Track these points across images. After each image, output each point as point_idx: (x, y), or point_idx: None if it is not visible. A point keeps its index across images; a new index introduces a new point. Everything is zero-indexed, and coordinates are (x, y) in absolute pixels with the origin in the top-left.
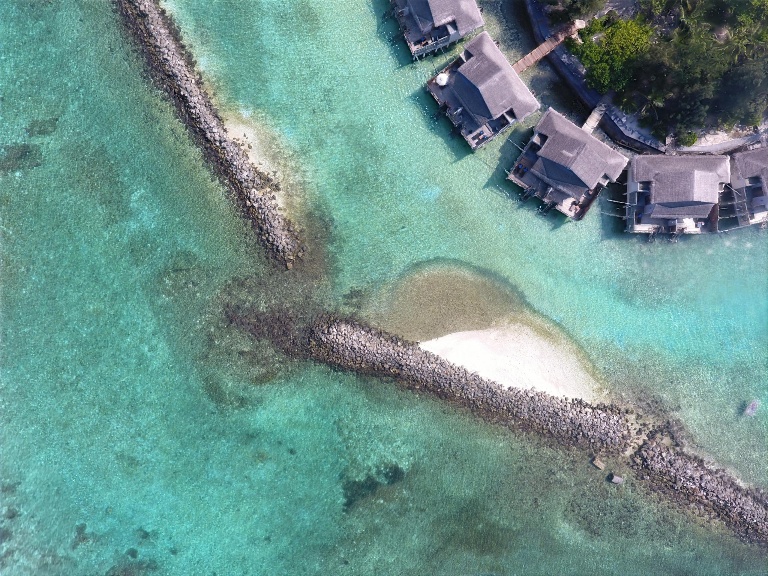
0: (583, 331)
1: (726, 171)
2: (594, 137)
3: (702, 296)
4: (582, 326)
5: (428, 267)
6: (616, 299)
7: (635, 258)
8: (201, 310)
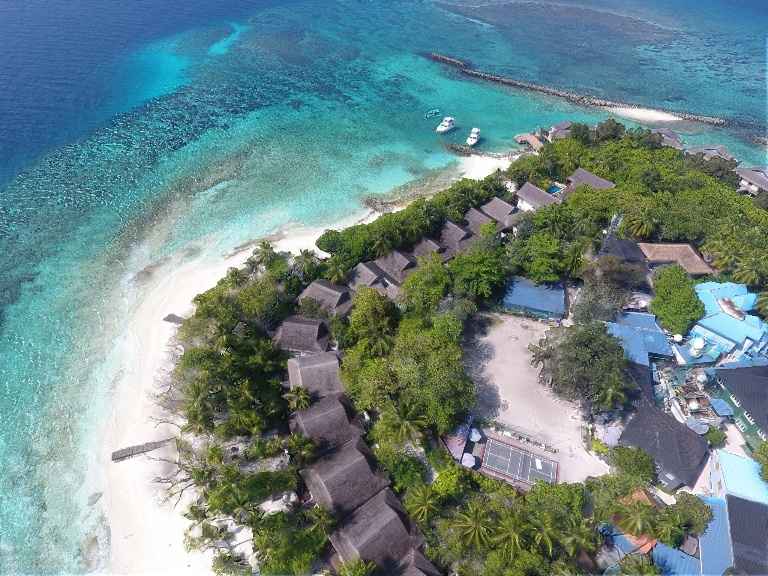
0: None
1: None
2: None
3: None
4: None
5: None
6: None
7: None
8: None
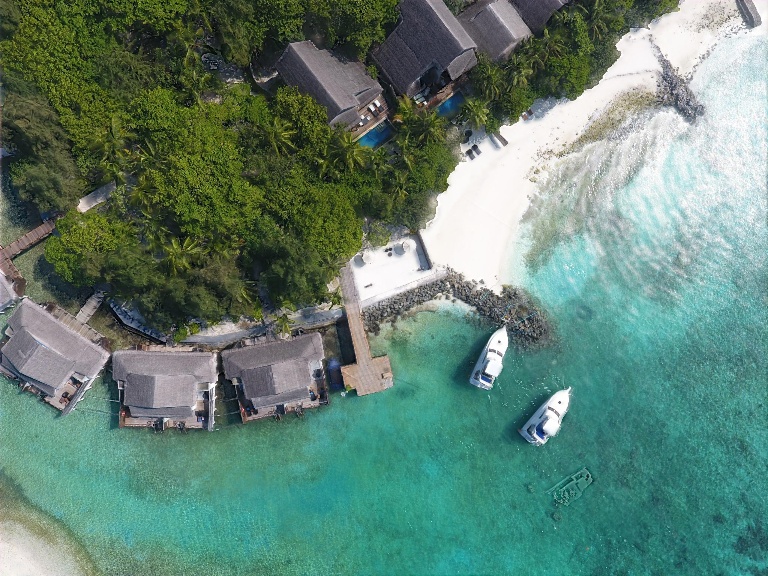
0: (85, 528)
1: (209, 370)
2: (71, 331)
3: (218, 489)
4: (85, 522)
5: None
6: (125, 492)
7: (146, 448)
8: None
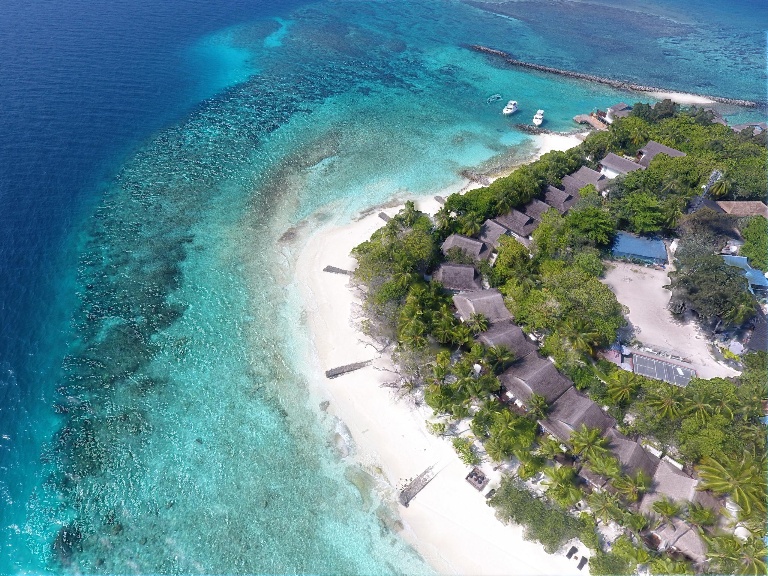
0: None
1: None
2: None
3: None
4: None
5: (730, 114)
6: None
7: None
8: None
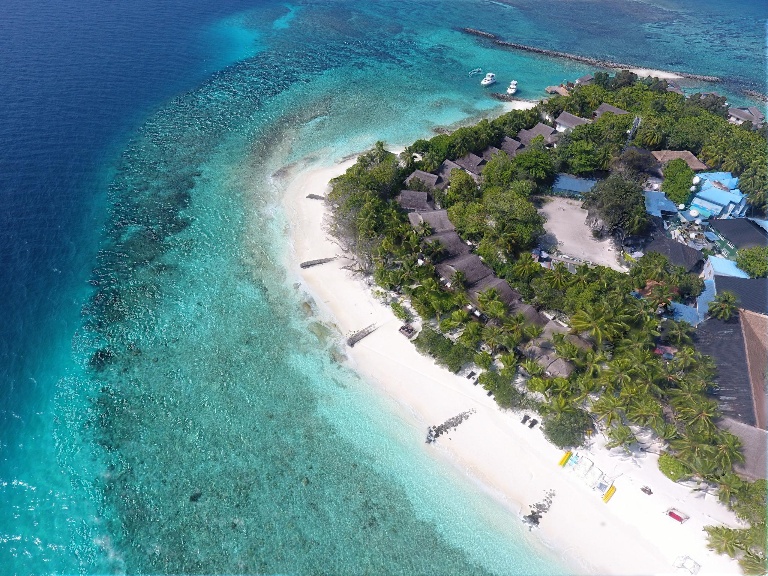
0: None
1: None
2: None
3: None
4: None
5: None
6: None
7: None
8: (764, 86)
